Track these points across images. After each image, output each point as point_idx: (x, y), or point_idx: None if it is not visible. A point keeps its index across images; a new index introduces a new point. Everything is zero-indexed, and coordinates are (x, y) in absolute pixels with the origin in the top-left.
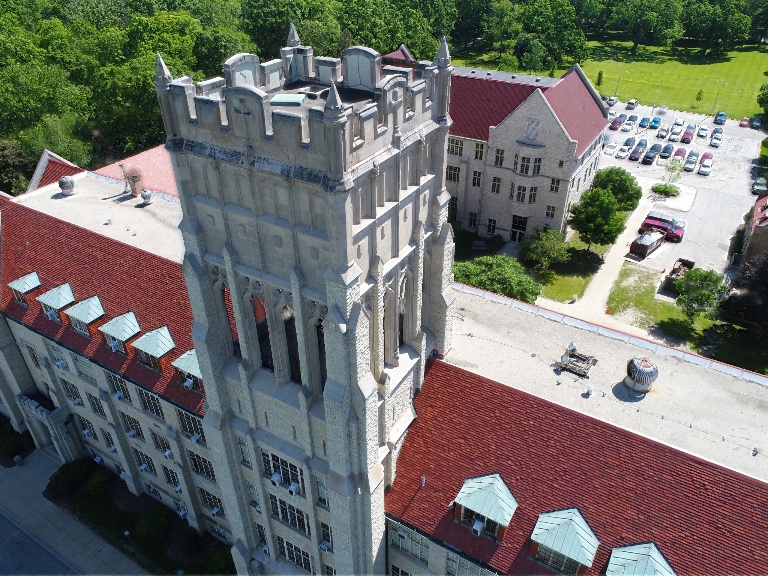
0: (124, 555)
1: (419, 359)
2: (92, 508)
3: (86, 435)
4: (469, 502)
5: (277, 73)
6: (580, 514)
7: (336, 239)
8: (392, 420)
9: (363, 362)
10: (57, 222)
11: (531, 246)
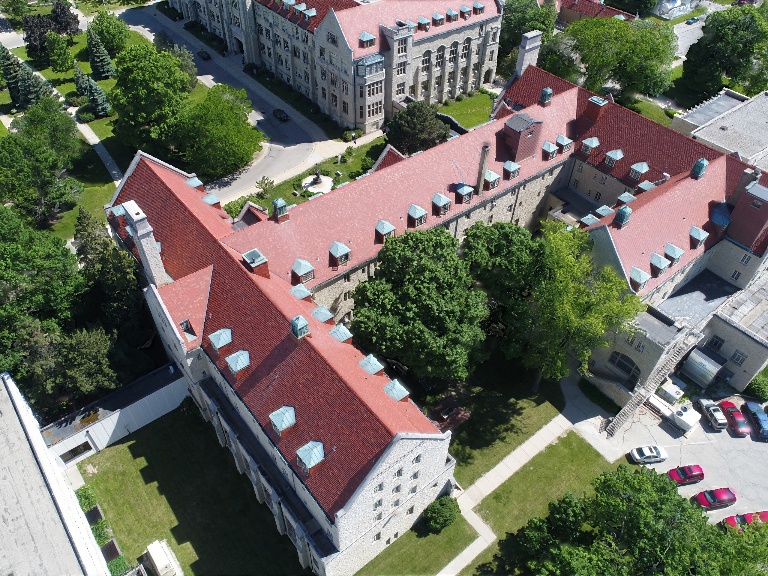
0: (201, 41)
1: None
2: (196, 32)
3: (199, 11)
4: None
5: None
6: None
7: None
8: None
9: None
10: None
11: None
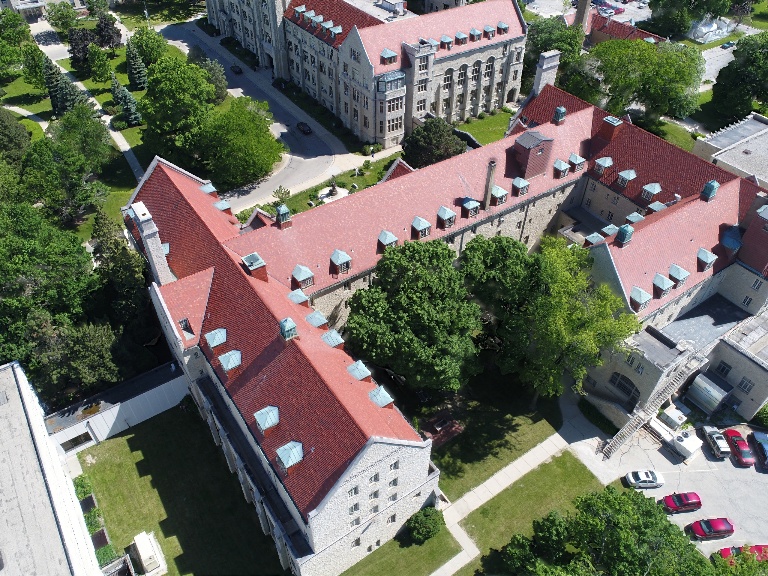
0: (235, 56)
1: None
2: (231, 48)
3: (235, 27)
4: None
5: None
6: None
7: None
8: None
9: None
10: None
11: None
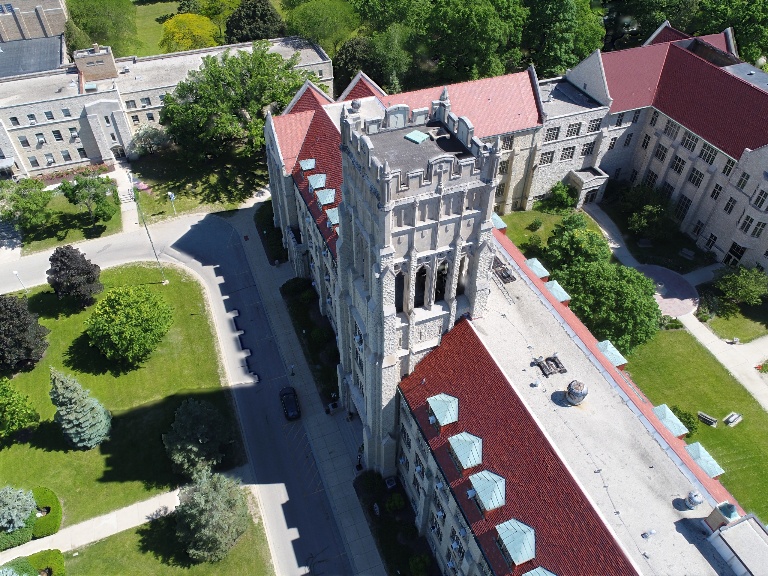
0: (299, 343)
1: (449, 313)
2: (298, 309)
3: (311, 266)
4: (433, 403)
5: (423, 116)
6: (482, 443)
7: (380, 231)
8: (419, 339)
9: (389, 297)
10: (336, 132)
11: (725, 276)
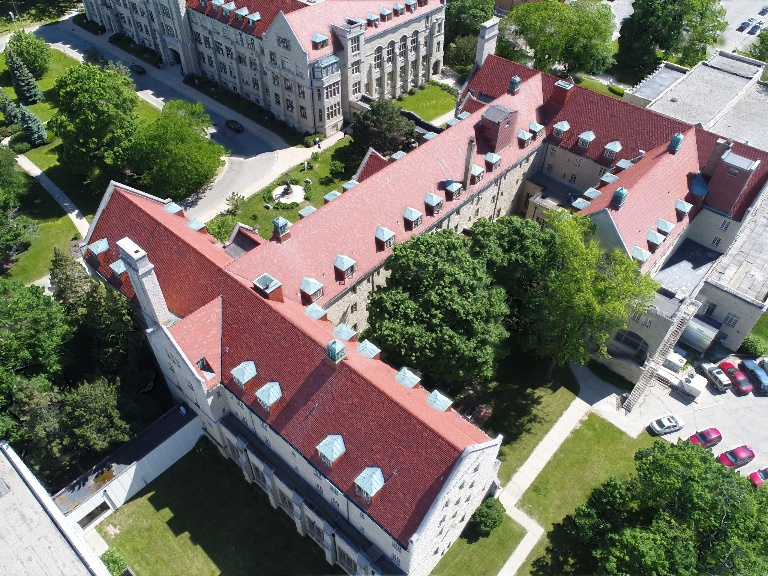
0: None
1: None
2: (123, 45)
3: (123, 22)
4: None
5: None
6: None
7: None
8: None
9: None
10: None
11: None
